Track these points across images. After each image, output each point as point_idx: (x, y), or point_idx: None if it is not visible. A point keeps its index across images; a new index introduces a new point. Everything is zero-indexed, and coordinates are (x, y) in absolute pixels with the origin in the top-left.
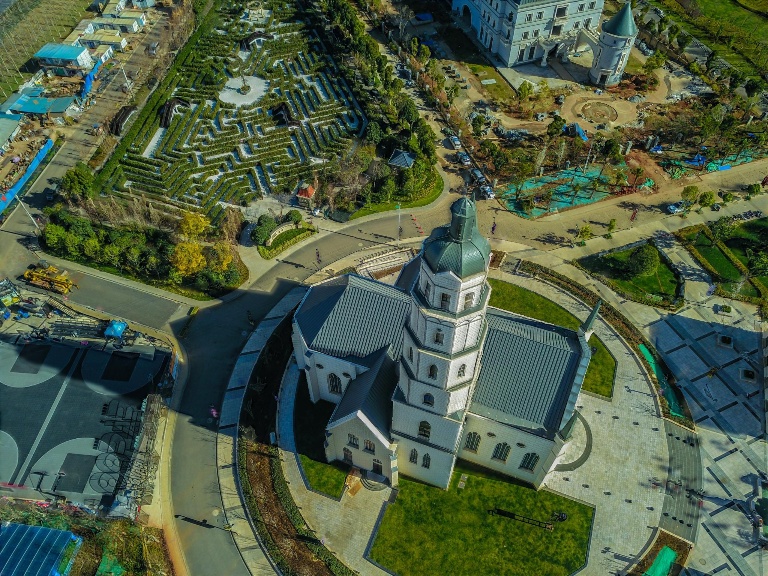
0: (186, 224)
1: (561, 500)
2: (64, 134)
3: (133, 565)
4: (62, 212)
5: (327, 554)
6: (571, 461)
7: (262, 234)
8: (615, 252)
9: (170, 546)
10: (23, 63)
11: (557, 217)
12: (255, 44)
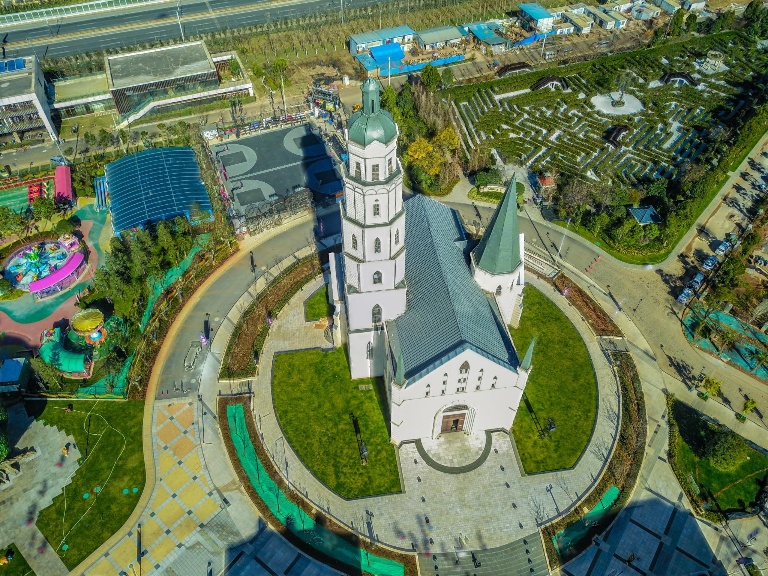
0: (440, 132)
1: (393, 463)
2: (476, 58)
3: (212, 247)
4: (408, 88)
5: (265, 331)
6: (434, 459)
7: (481, 178)
8: (724, 431)
9: (232, 258)
10: (512, 8)
11: (718, 363)
12: (676, 82)
